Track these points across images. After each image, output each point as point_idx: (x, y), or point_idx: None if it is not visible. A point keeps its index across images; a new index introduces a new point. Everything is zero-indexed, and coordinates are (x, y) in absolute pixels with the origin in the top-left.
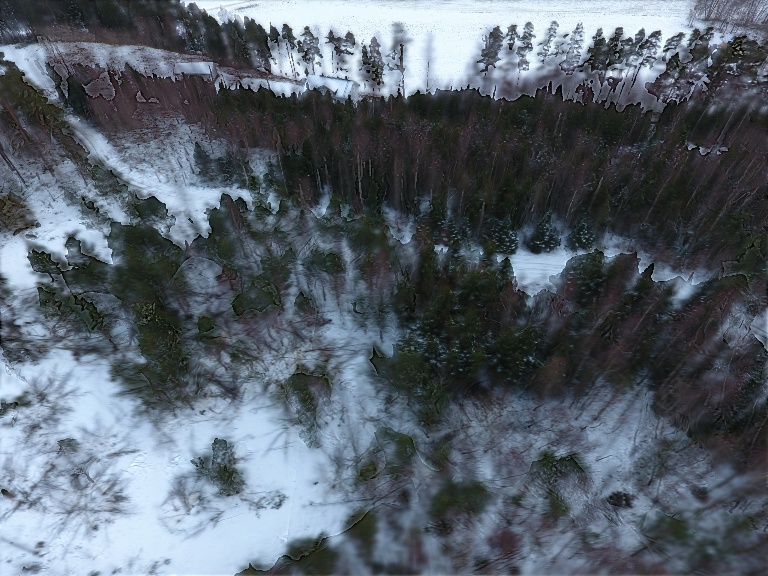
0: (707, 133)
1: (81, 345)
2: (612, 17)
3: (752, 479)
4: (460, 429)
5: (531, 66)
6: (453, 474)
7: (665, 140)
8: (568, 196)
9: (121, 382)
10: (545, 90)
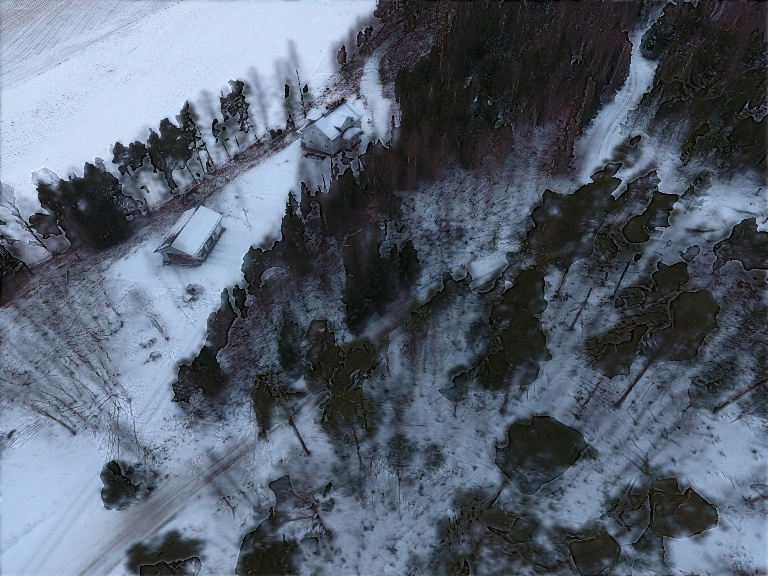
0: None
1: None
2: (167, 12)
3: None
4: (767, 88)
5: (242, 62)
6: None
7: None
8: (586, 33)
9: None
10: None
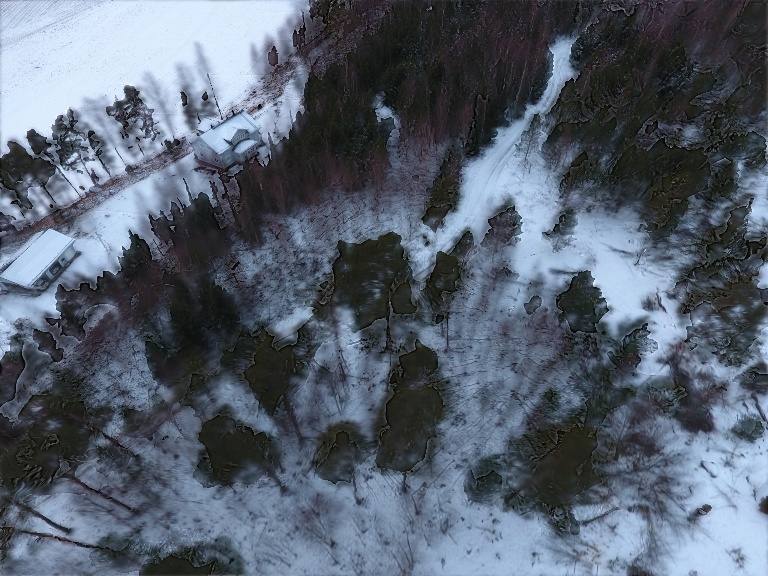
0: (422, 4)
1: (706, 227)
2: (112, 5)
3: (730, 24)
4: None
5: (176, 60)
6: (759, 72)
7: (469, 0)
8: None
9: (726, 205)
10: (276, 50)
